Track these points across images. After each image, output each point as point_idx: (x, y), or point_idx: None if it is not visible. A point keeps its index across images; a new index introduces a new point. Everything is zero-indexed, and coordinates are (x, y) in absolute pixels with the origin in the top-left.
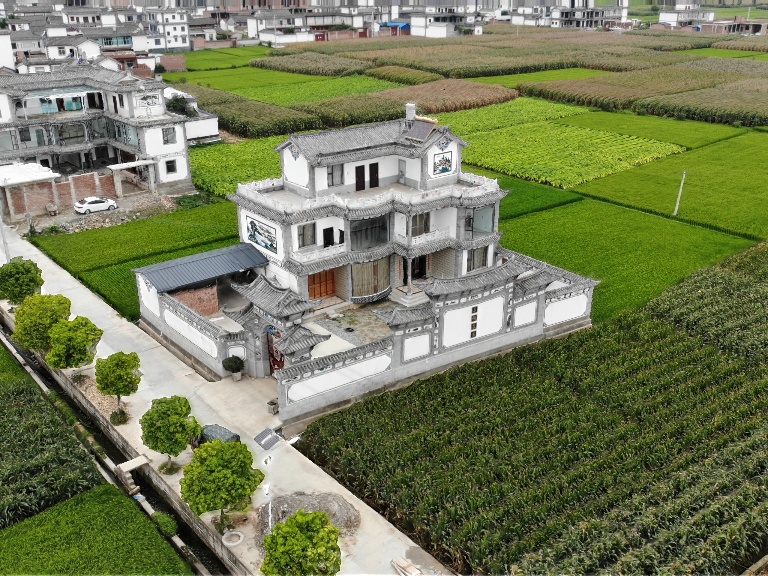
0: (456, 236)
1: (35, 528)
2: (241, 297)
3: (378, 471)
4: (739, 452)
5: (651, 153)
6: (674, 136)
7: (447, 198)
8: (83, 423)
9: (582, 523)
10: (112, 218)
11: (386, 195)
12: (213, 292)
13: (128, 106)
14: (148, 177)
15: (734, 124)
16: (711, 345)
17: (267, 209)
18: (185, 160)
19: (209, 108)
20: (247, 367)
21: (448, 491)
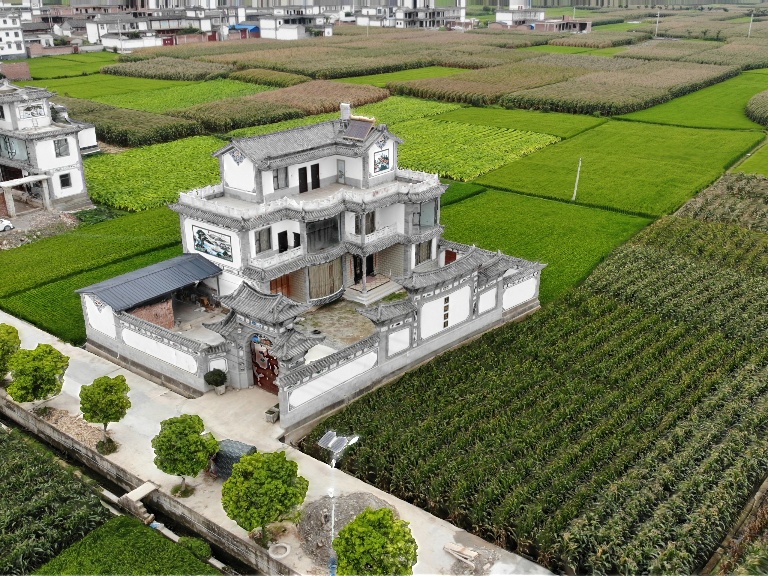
0: (404, 231)
1: (57, 573)
2: (193, 310)
3: (402, 464)
4: (715, 405)
5: (532, 144)
6: (547, 127)
7: (394, 195)
8: (61, 458)
9: (612, 485)
10: (10, 239)
11: (337, 195)
12: (169, 307)
13: (10, 118)
14: (42, 193)
15: (594, 114)
16: None
17: (220, 216)
18: (80, 173)
19: (77, 118)
20: (229, 379)
21: (478, 474)
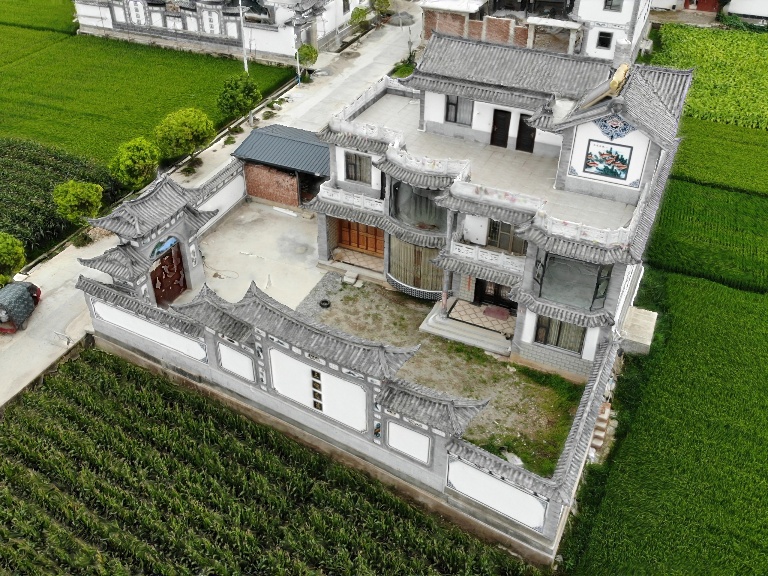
0: None
1: None
2: None
3: None
4: None
5: None
6: None
7: (525, 213)
8: None
9: None
10: None
11: (450, 164)
12: (293, 183)
13: None
14: (569, 44)
15: None
16: None
17: None
18: (626, 37)
19: None
20: None
21: None
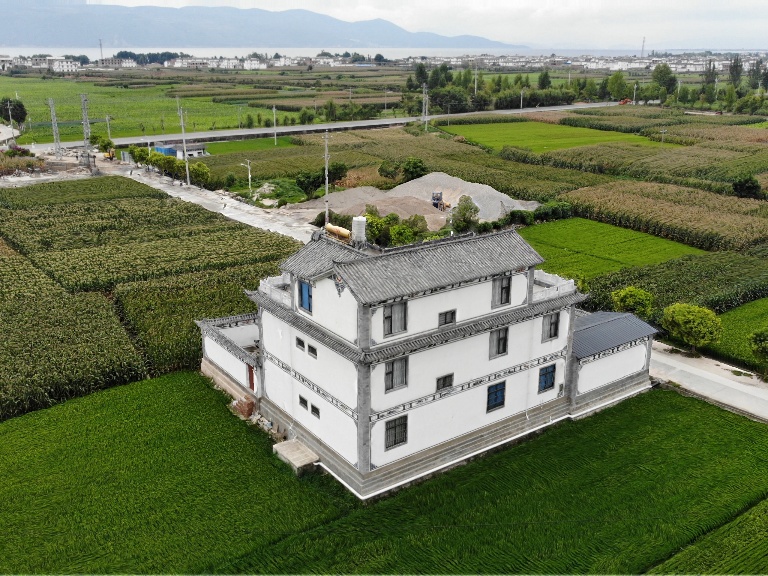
0: None
1: None
2: None
3: None
4: None
5: None
6: None
7: None
8: None
9: None
10: None
11: None
12: None
13: None
14: None
15: None
16: None
17: None
18: None
19: None
20: None
21: None
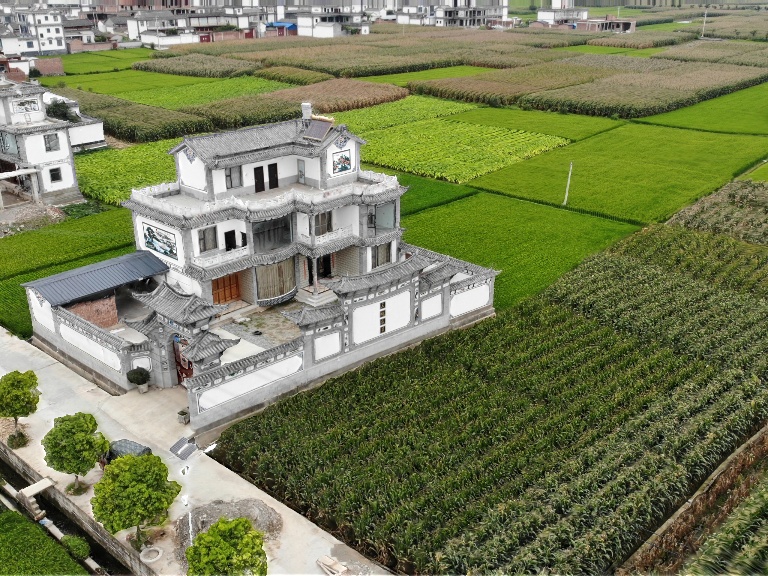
0: (359, 234)
1: None
2: (141, 306)
3: (297, 472)
4: (639, 424)
5: (539, 146)
6: (559, 129)
7: (348, 196)
8: None
9: (500, 505)
10: None
11: (287, 195)
12: (111, 303)
13: (4, 112)
14: (31, 187)
15: (613, 117)
16: (606, 326)
17: (164, 214)
18: (70, 167)
19: (92, 113)
20: (153, 378)
21: (369, 486)
